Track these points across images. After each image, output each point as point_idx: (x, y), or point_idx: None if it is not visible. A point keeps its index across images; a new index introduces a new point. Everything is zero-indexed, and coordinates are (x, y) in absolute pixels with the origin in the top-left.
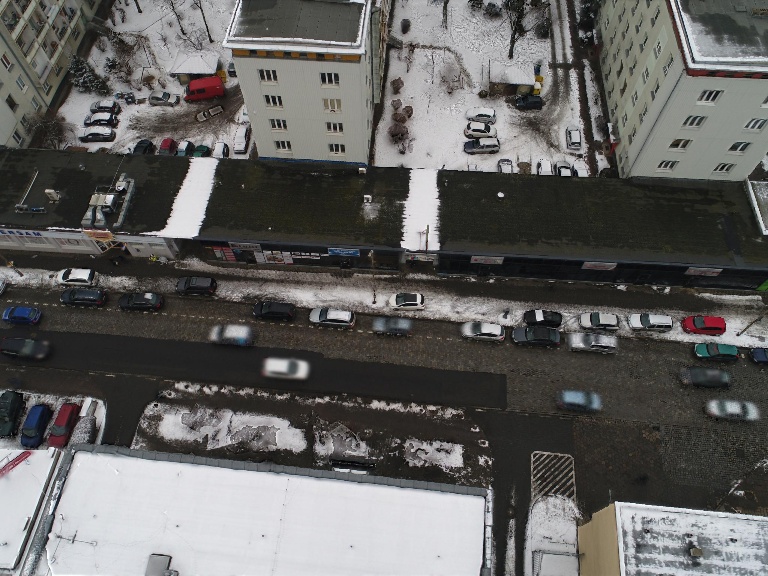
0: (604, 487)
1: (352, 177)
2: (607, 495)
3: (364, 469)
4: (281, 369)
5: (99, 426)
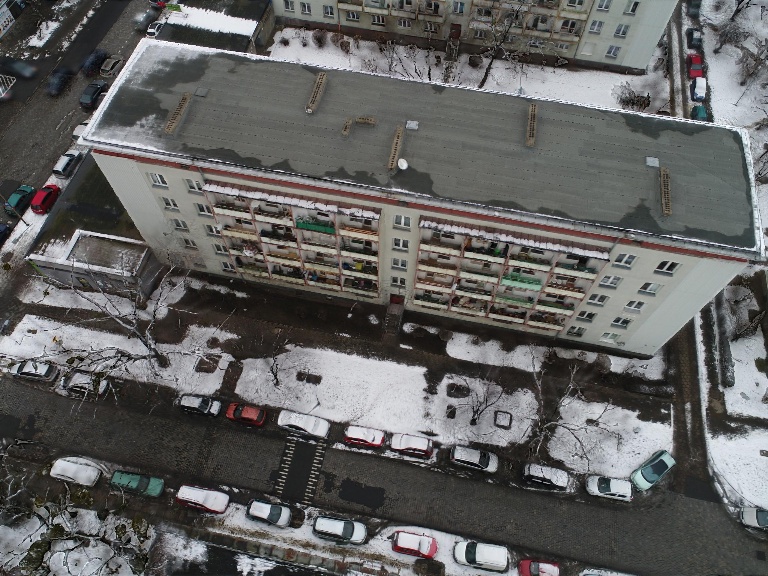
0: None
1: None
2: None
3: (53, 4)
4: None
5: None
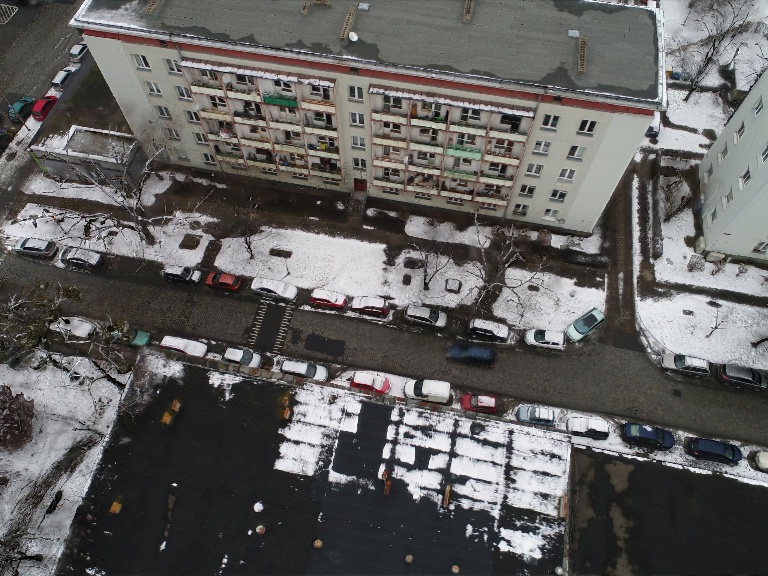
0: None
1: None
2: None
3: None
4: None
5: None
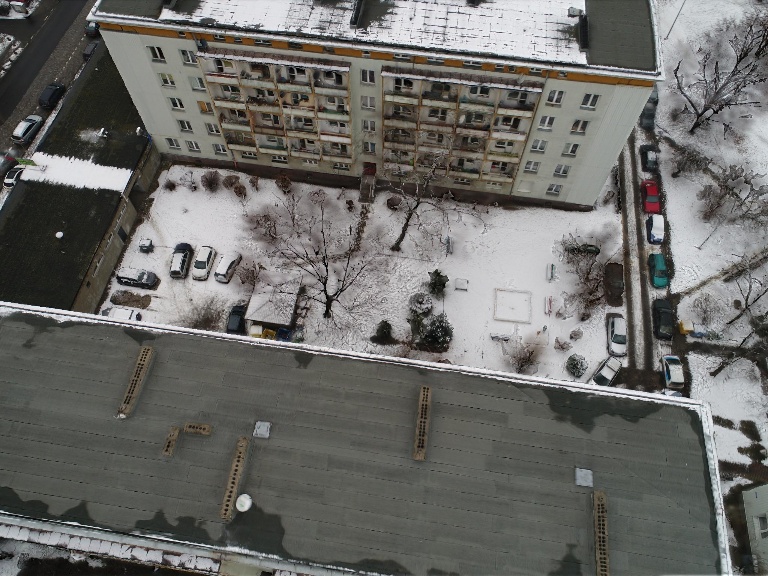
0: None
1: (138, 126)
2: None
3: None
4: (3, 101)
5: (9, 16)
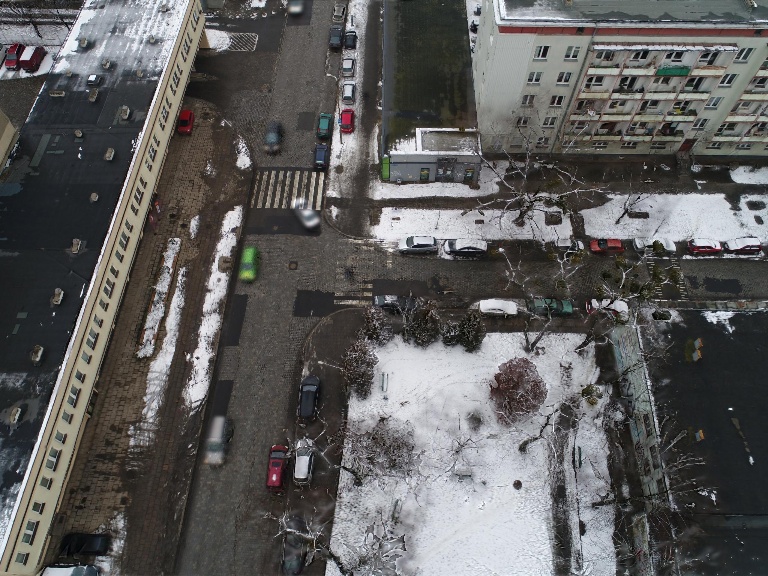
0: (233, 63)
1: None
2: (229, 63)
3: None
4: None
5: None
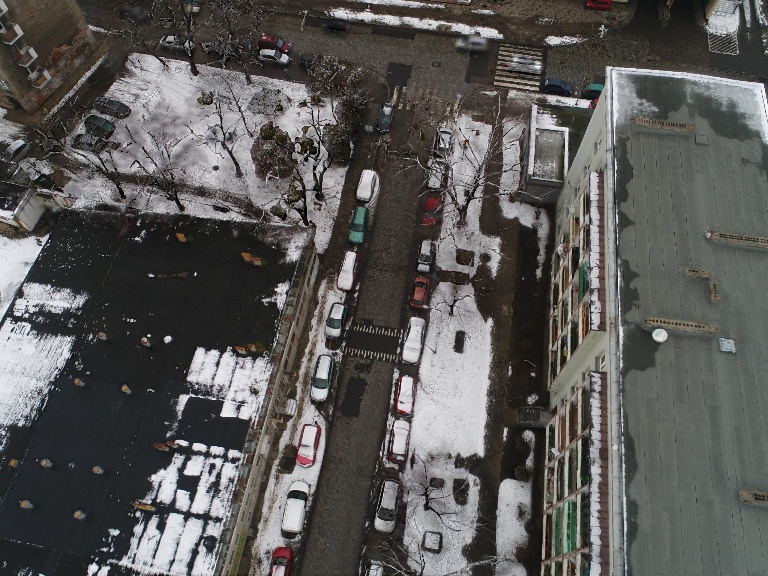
0: (689, 36)
1: None
2: (687, 33)
3: None
4: None
5: None
